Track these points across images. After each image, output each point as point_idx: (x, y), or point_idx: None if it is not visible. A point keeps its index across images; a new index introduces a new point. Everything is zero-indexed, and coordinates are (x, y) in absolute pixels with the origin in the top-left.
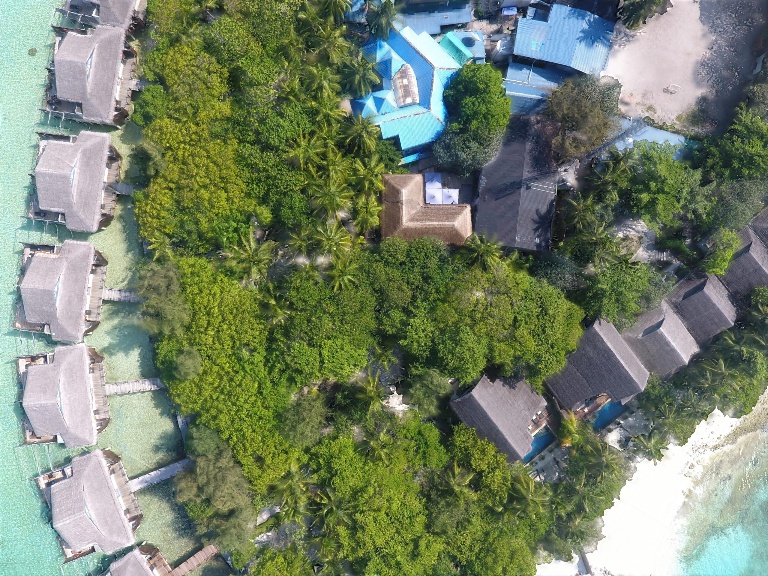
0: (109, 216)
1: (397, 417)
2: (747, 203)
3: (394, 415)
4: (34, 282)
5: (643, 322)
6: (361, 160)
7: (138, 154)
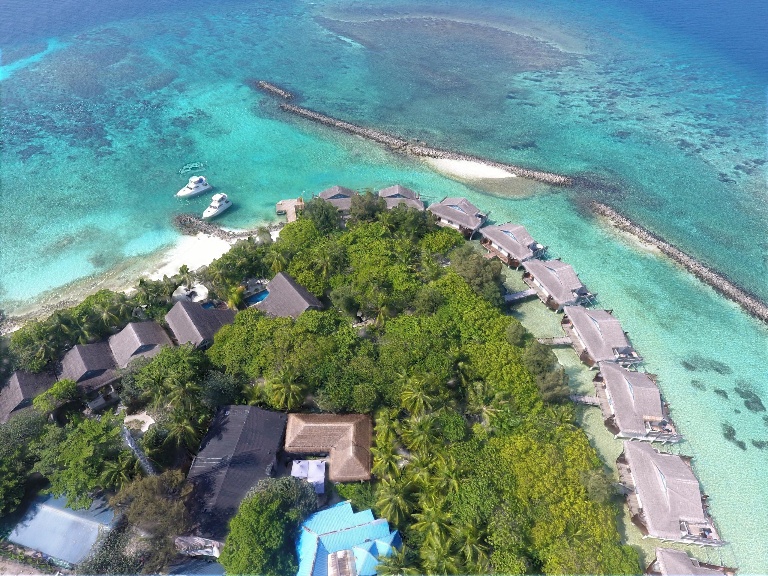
0: (619, 459)
1: (362, 305)
2: (4, 433)
3: (364, 306)
4: (651, 393)
5: (150, 356)
6: (395, 474)
7: None
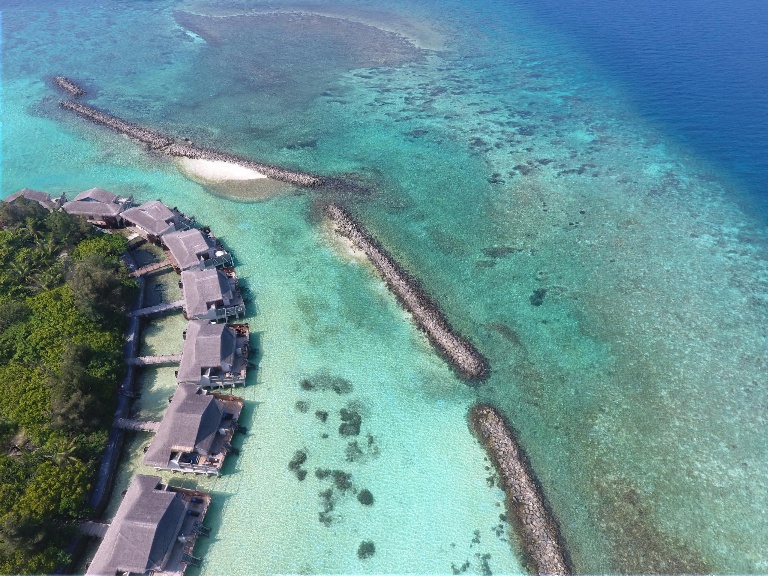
0: None
1: None
2: None
3: None
4: (190, 420)
5: None
6: None
7: (18, 529)
